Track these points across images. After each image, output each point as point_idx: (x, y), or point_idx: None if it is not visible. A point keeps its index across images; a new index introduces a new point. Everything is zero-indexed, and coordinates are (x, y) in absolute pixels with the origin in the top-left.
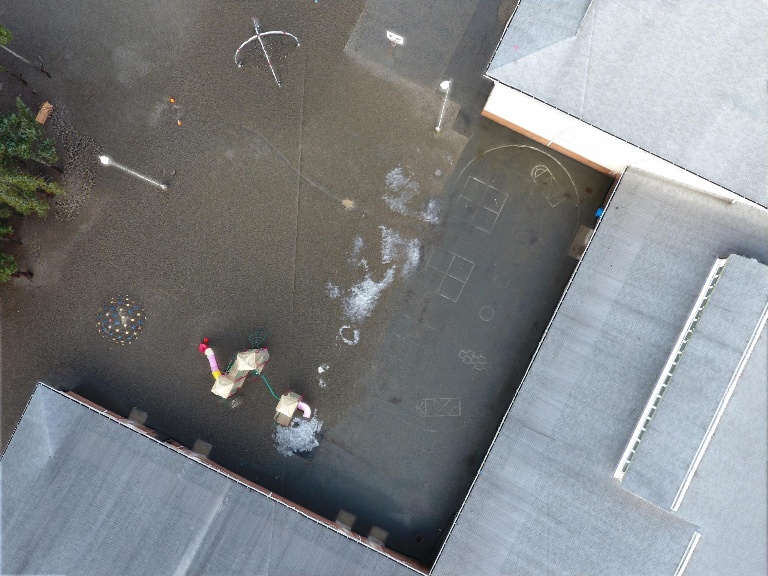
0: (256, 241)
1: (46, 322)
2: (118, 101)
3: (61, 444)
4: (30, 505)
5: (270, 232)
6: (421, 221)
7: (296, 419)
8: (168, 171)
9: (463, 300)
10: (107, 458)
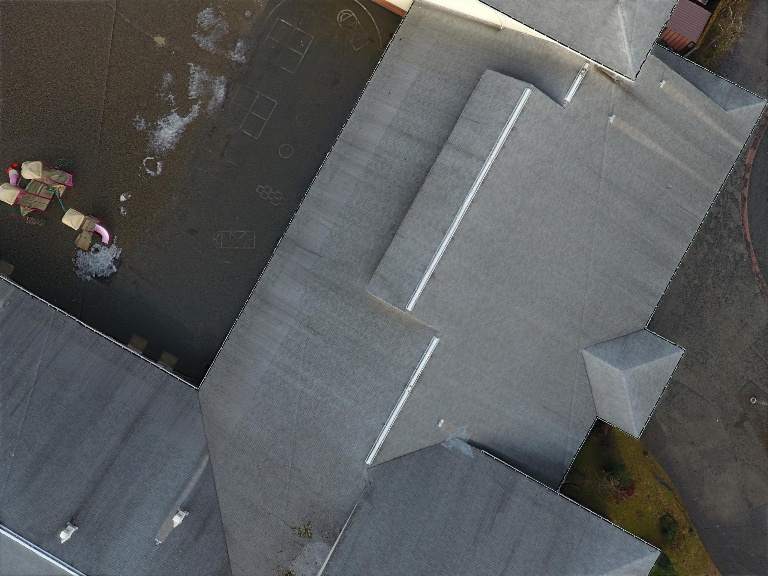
0: (69, 72)
1: None
2: None
3: None
4: None
5: (83, 64)
6: (228, 59)
7: (96, 245)
8: None
9: (264, 137)
10: None
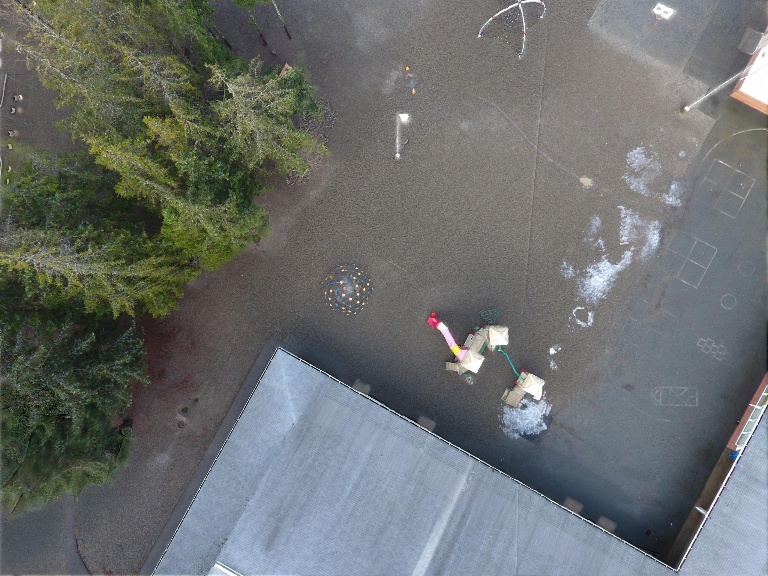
0: (490, 215)
1: (270, 288)
2: (356, 66)
3: (304, 411)
4: (277, 471)
5: (504, 207)
6: (662, 203)
7: (524, 400)
8: (401, 140)
9: (704, 286)
10: (350, 428)
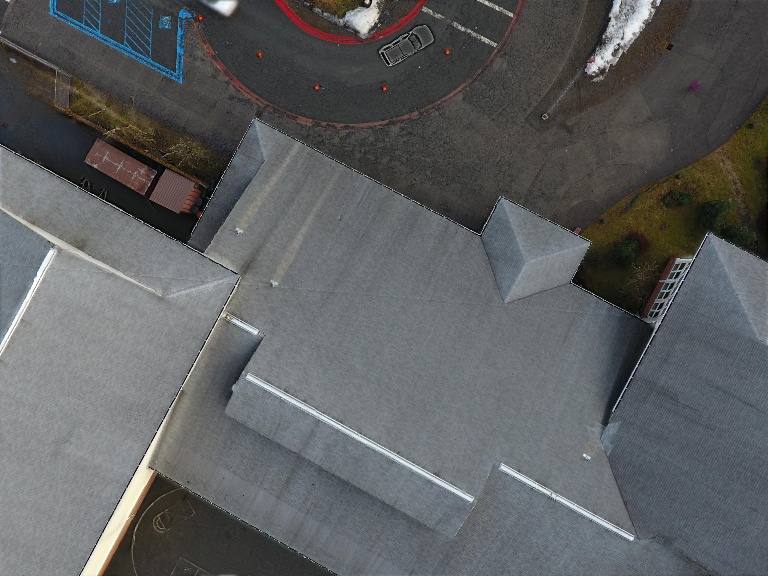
0: None
1: None
2: None
3: None
4: None
5: None
6: None
7: None
8: None
9: None
10: None
